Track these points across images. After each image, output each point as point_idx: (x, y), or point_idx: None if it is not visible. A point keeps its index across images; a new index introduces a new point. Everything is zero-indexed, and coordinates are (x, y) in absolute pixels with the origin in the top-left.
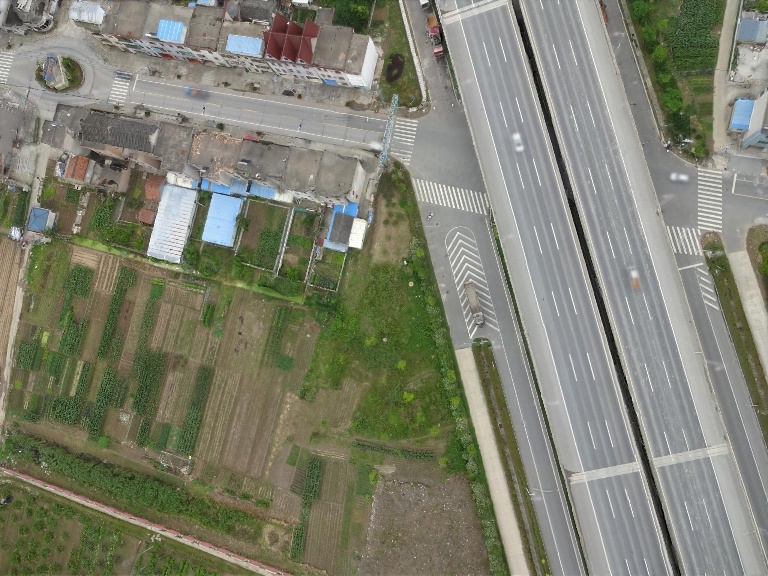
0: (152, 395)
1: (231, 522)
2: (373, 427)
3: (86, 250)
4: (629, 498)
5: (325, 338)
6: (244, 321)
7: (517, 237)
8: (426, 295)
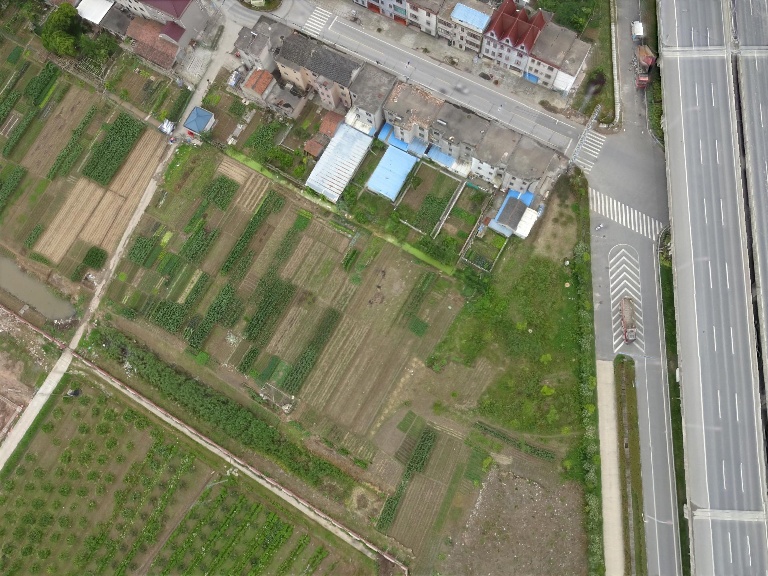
0: (269, 324)
1: (322, 474)
2: (500, 413)
3: (237, 163)
4: (750, 546)
5: (468, 314)
6: (386, 276)
7: (690, 266)
8: (582, 299)
